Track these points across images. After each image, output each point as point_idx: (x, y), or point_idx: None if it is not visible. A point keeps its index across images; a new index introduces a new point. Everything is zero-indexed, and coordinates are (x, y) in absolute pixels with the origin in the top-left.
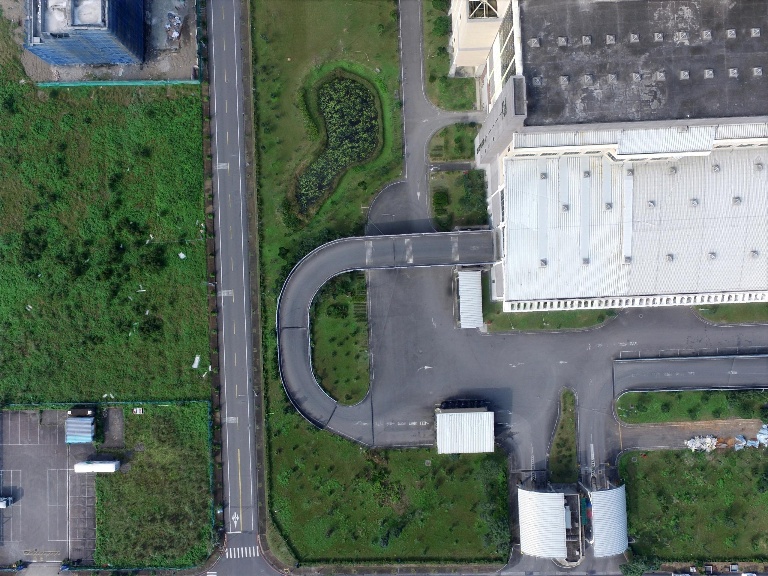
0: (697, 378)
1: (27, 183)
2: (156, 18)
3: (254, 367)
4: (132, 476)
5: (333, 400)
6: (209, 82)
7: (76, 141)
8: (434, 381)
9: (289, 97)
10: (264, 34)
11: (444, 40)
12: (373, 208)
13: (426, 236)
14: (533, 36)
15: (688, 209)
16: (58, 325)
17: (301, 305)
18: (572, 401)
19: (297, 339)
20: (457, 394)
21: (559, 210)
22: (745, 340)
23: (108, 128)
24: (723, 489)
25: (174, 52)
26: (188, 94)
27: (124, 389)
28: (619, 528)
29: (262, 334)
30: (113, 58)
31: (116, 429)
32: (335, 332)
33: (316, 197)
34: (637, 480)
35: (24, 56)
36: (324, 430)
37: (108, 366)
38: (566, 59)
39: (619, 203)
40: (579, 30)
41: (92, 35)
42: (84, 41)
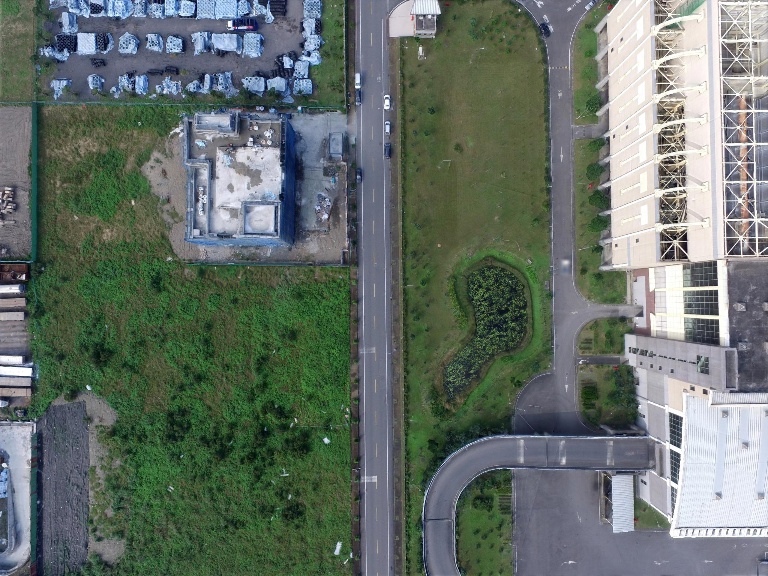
0: None
1: (172, 363)
2: (306, 199)
3: (396, 555)
4: None
5: None
6: (358, 265)
7: (222, 321)
8: None
9: (439, 284)
10: None
11: (596, 232)
12: (520, 399)
13: (580, 439)
14: (739, 300)
15: None
16: (199, 507)
17: (448, 498)
18: None
19: (442, 531)
20: None
21: (738, 447)
22: None
23: (255, 309)
24: None
25: (323, 234)
26: (336, 277)
27: (265, 575)
28: None
29: (406, 523)
30: None
31: None
32: (480, 524)
33: (463, 385)
34: None
35: (172, 233)
36: None
37: (249, 551)
38: None
39: None
40: None
41: (259, 238)
42: (248, 240)
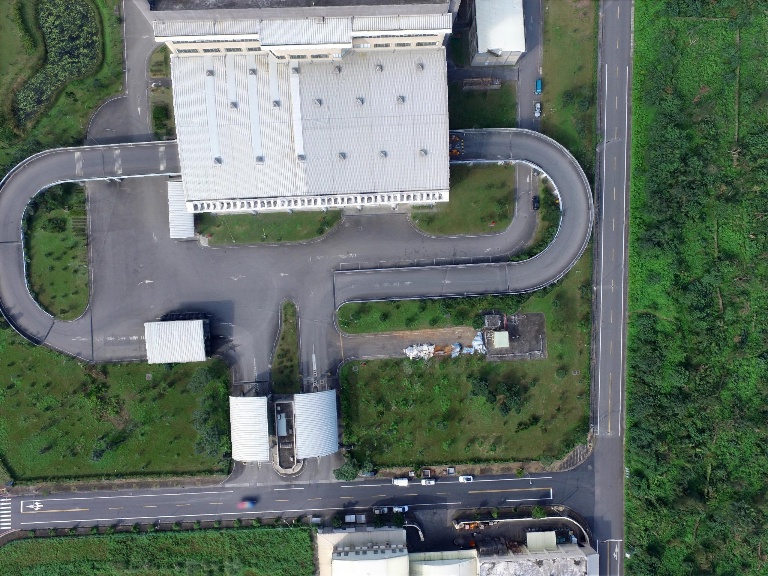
0: (413, 288)
1: None
2: None
3: None
4: None
5: (50, 315)
6: None
7: None
8: (155, 295)
9: (5, 11)
10: None
11: None
12: (93, 123)
13: (134, 146)
14: None
15: (355, 107)
16: None
17: (14, 219)
18: (293, 312)
19: (11, 254)
20: (178, 308)
21: (228, 107)
22: (460, 251)
23: None
24: (439, 395)
25: None
26: None
27: None
28: (324, 430)
29: None
30: None
31: None
32: (52, 247)
33: (35, 112)
34: (357, 388)
35: None
36: (41, 346)
37: None
38: None
39: (287, 101)
40: None
41: None
42: None
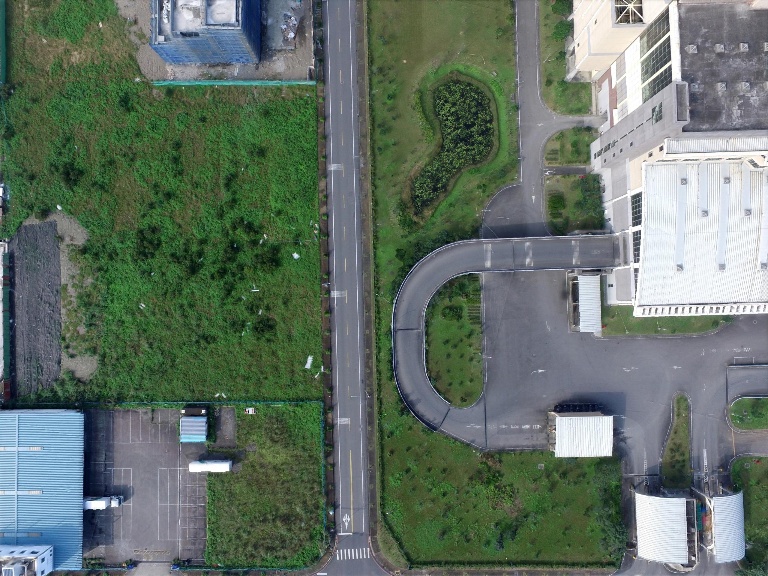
0: None
1: (141, 181)
2: (272, 18)
3: (367, 368)
4: (243, 476)
5: (447, 402)
6: (324, 83)
7: (191, 140)
8: (548, 384)
9: (405, 99)
10: (381, 36)
11: (561, 44)
12: (488, 211)
13: (546, 240)
14: (691, 42)
15: None
16: (171, 324)
17: (417, 307)
18: (686, 406)
19: (412, 341)
20: (570, 398)
21: (698, 216)
22: None
23: (223, 127)
24: None
25: (289, 52)
26: (303, 95)
27: (237, 389)
28: (739, 534)
29: (376, 335)
30: (232, 58)
31: (228, 429)
32: (449, 334)
33: (430, 199)
34: (750, 486)
35: (140, 54)
36: (437, 432)
37: (221, 365)
38: (723, 66)
39: (758, 209)
40: (736, 37)
41: (222, 35)
42: (212, 40)
